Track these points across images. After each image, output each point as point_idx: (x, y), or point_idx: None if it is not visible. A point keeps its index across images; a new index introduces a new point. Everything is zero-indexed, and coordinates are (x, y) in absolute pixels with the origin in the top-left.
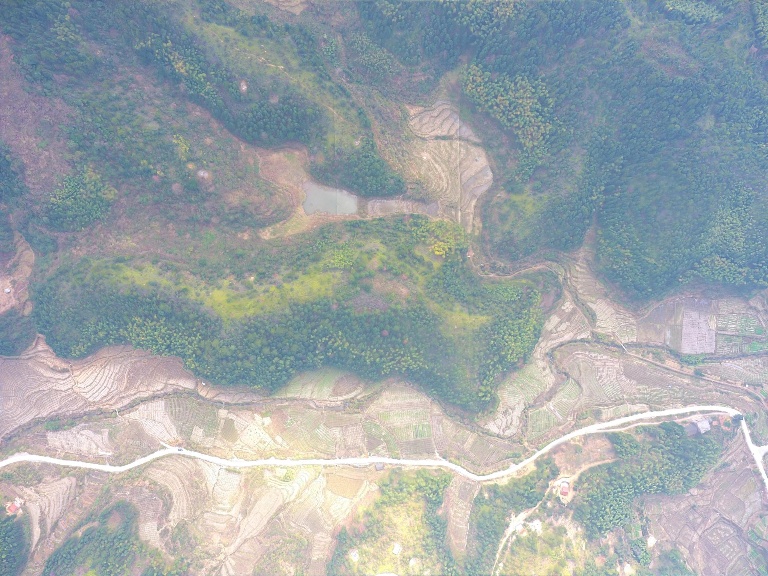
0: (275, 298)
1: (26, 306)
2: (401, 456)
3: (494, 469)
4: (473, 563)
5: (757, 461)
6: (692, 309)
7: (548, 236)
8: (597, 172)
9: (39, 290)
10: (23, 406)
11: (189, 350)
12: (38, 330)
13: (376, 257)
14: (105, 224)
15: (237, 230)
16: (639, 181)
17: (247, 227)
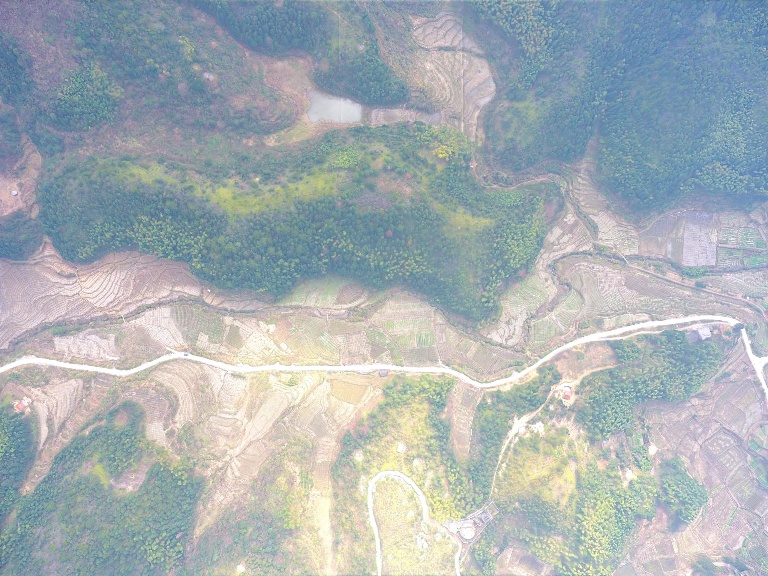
0: (280, 197)
1: (33, 209)
2: (405, 363)
3: (497, 377)
4: (476, 465)
5: (757, 371)
6: (693, 222)
7: (550, 145)
8: (599, 76)
9: (46, 188)
10: (30, 311)
11: (195, 250)
12: (45, 230)
13: (380, 158)
14: (111, 124)
15: (242, 136)
16: (641, 85)
17: (252, 133)
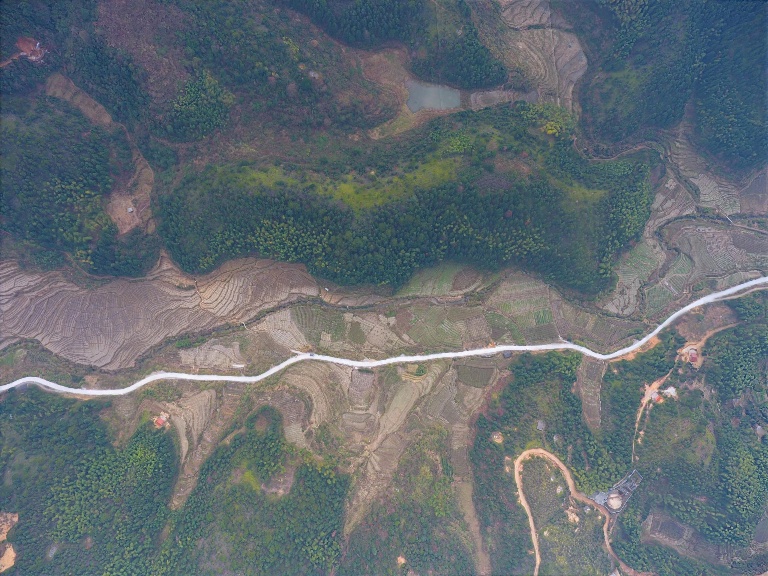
0: (400, 187)
1: (149, 225)
2: (526, 343)
3: (618, 347)
4: (612, 436)
5: None
6: None
7: (649, 112)
8: (698, 38)
9: (167, 201)
10: (153, 327)
11: (319, 248)
12: (167, 244)
13: (493, 140)
14: (224, 132)
15: (347, 132)
16: (740, 43)
17: (357, 128)
